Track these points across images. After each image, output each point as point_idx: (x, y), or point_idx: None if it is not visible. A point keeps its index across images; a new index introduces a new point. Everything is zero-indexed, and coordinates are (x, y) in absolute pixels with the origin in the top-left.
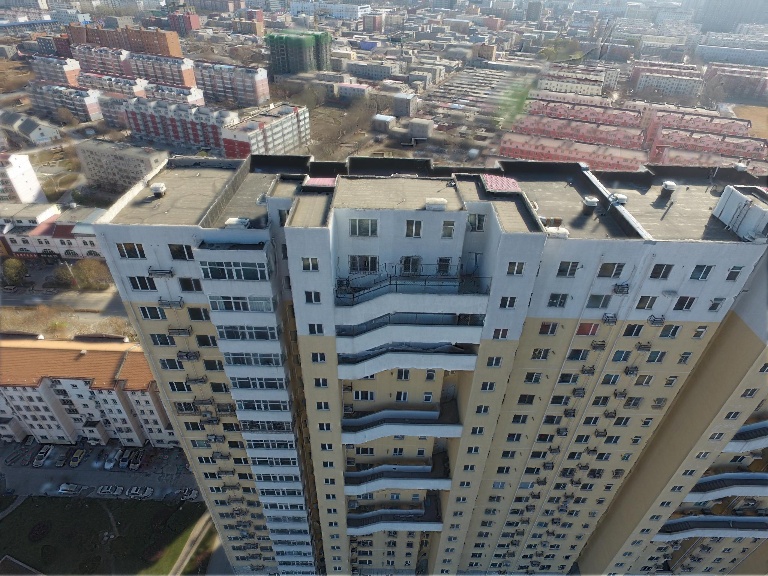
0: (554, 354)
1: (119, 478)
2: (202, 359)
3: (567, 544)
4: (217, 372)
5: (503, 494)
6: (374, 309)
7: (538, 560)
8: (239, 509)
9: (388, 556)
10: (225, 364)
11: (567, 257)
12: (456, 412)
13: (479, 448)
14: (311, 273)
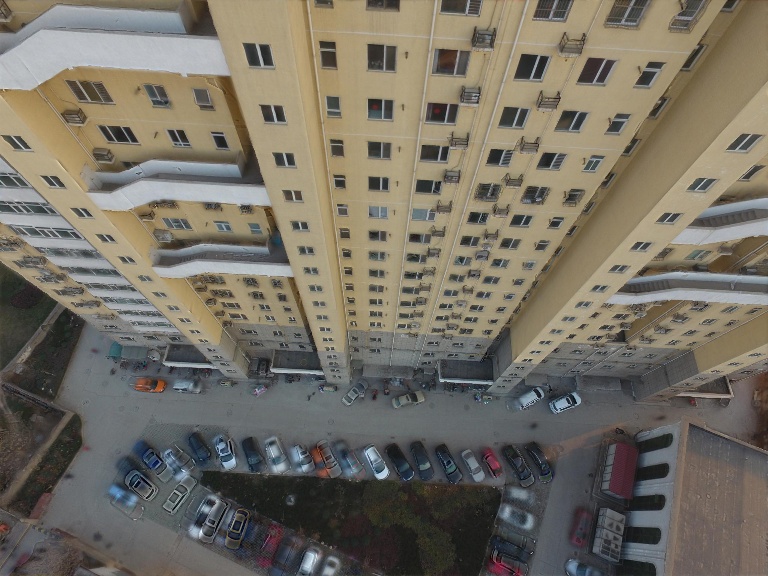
0: None
1: None
2: None
3: (493, 305)
4: None
5: (388, 228)
6: None
7: (456, 323)
8: (7, 238)
9: (262, 310)
10: None
11: None
12: None
13: (284, 110)
14: None
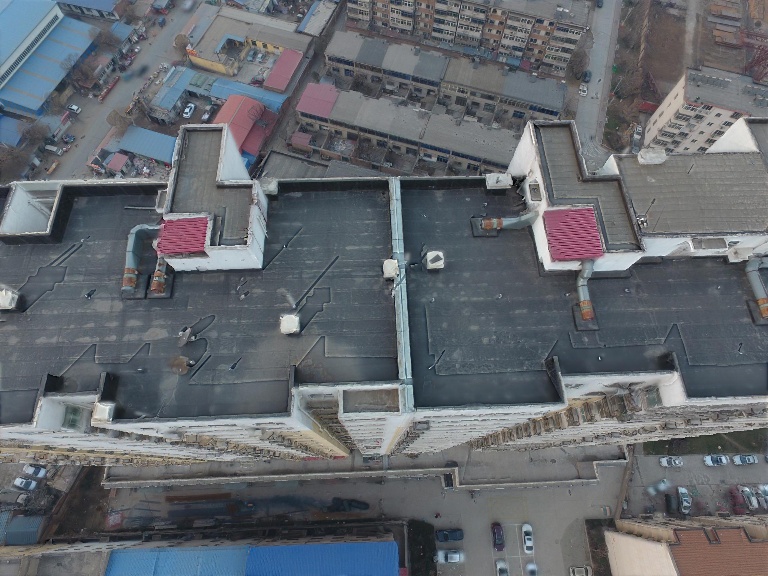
0: None
1: (748, 476)
2: None
3: None
4: None
5: None
6: None
7: None
8: None
9: None
10: None
11: None
12: None
13: None
14: None
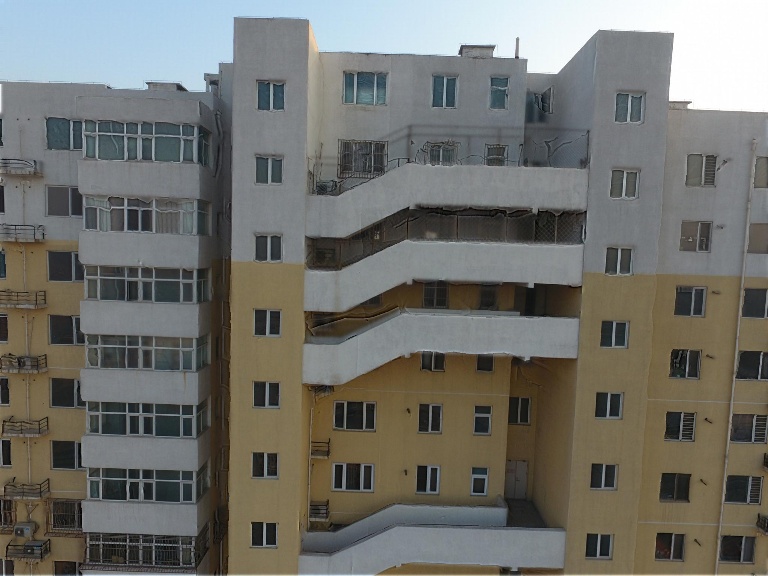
0: (712, 358)
1: None
2: (49, 377)
3: None
4: (71, 410)
5: None
6: (380, 198)
7: None
8: None
9: None
10: (85, 367)
11: (696, 145)
12: (539, 521)
13: None
14: (270, 113)
